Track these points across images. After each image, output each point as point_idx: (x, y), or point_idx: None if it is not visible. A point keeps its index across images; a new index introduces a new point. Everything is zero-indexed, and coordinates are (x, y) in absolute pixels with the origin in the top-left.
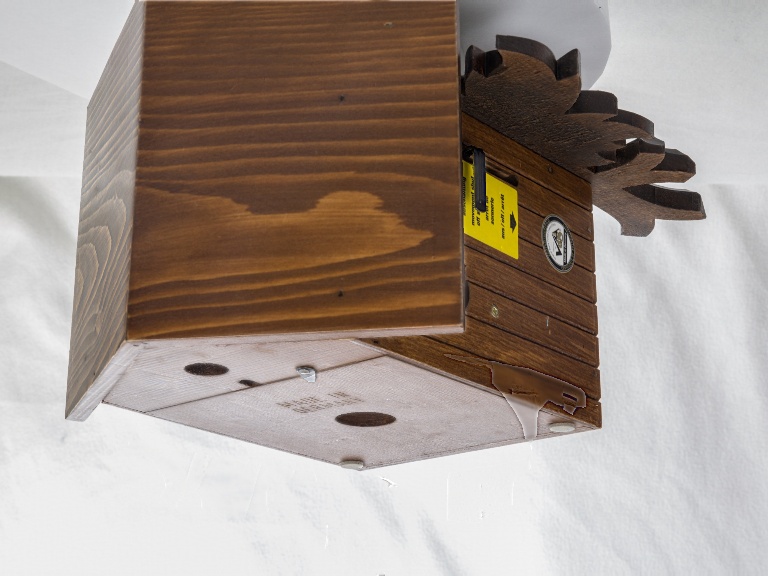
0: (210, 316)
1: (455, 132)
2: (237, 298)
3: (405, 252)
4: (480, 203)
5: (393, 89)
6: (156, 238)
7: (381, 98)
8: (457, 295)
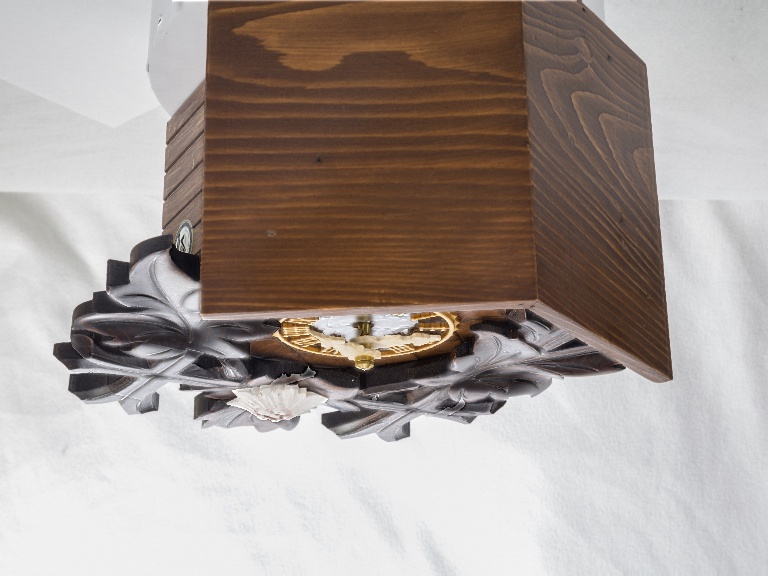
0: None
1: (208, 122)
2: None
3: (259, 16)
4: None
5: (267, 167)
6: (499, 31)
7: (279, 158)
8: None
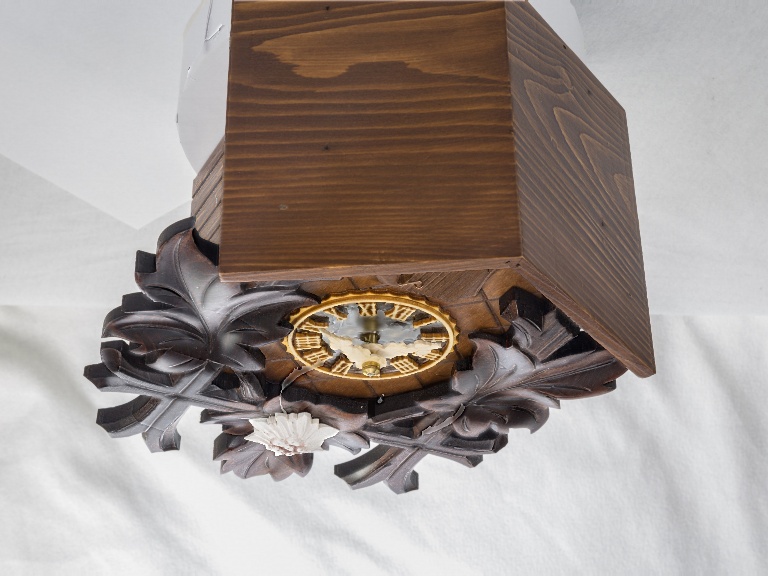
0: None
1: (229, 120)
2: (412, 4)
3: (275, 36)
4: None
5: (281, 154)
6: (486, 43)
7: (292, 147)
8: (235, 9)
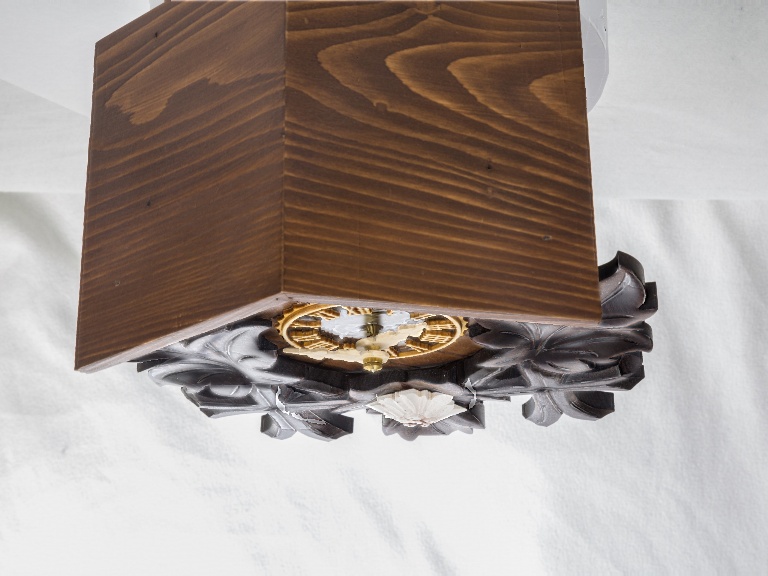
0: None
1: (86, 195)
2: (216, 2)
3: (120, 84)
4: None
5: (118, 222)
6: (269, 28)
7: (125, 212)
8: (96, 63)
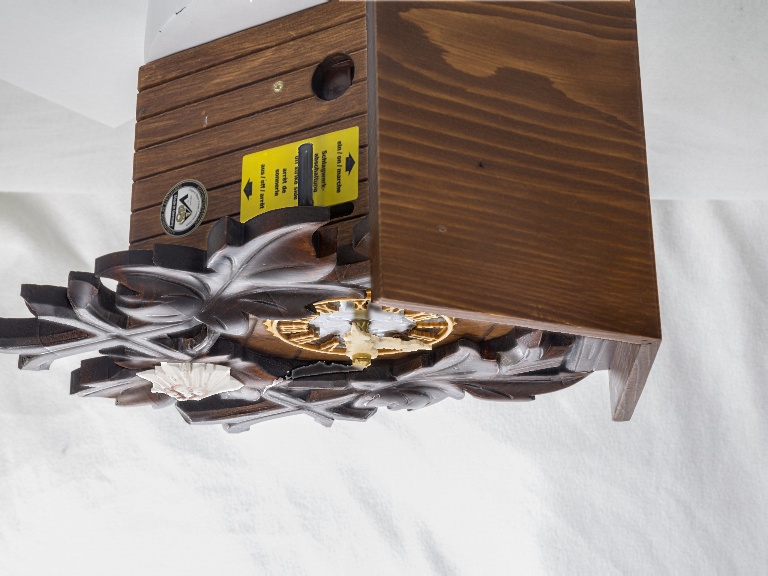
0: (574, 0)
1: (381, 102)
2: (554, 9)
3: (422, 6)
4: (307, 150)
5: (436, 161)
6: (622, 80)
7: (447, 155)
8: None
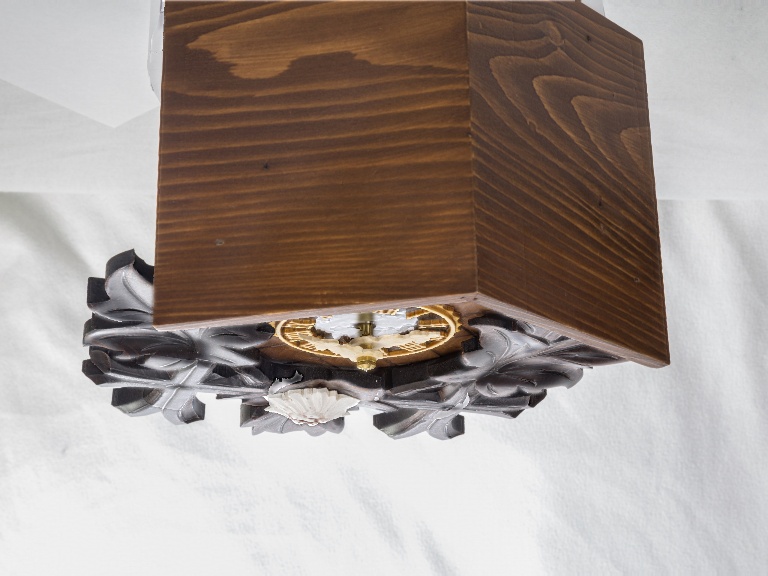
0: None
1: (162, 138)
2: None
3: (211, 29)
4: None
5: (217, 177)
6: (442, 22)
7: (229, 168)
8: None
